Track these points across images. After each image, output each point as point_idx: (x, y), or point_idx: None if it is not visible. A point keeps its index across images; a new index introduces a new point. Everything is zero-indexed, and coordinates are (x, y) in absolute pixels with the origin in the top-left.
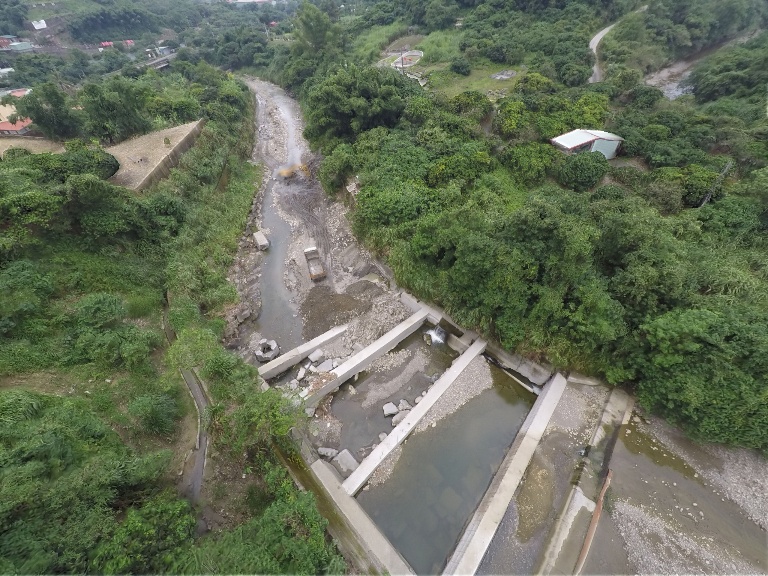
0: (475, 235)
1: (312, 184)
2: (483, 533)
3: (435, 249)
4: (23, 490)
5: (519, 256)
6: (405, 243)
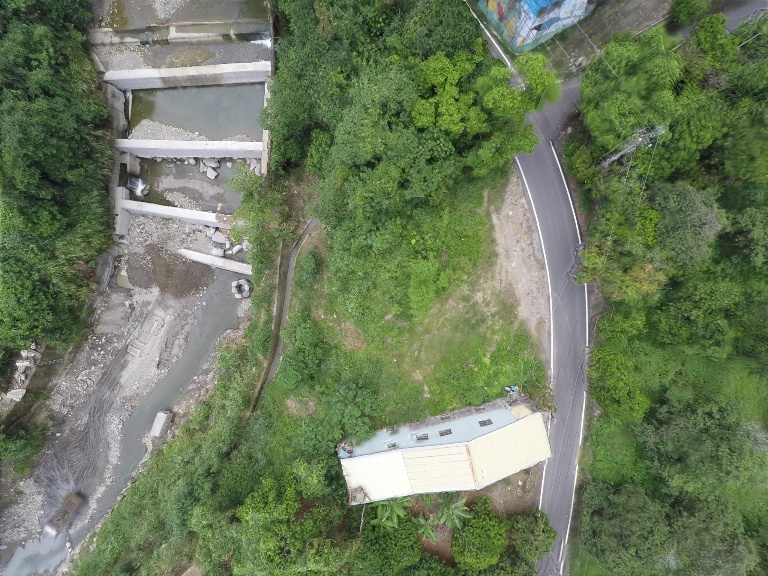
0: (6, 144)
1: (43, 484)
2: (224, 69)
3: (47, 192)
4: (329, 178)
5: (8, 102)
6: (59, 243)
